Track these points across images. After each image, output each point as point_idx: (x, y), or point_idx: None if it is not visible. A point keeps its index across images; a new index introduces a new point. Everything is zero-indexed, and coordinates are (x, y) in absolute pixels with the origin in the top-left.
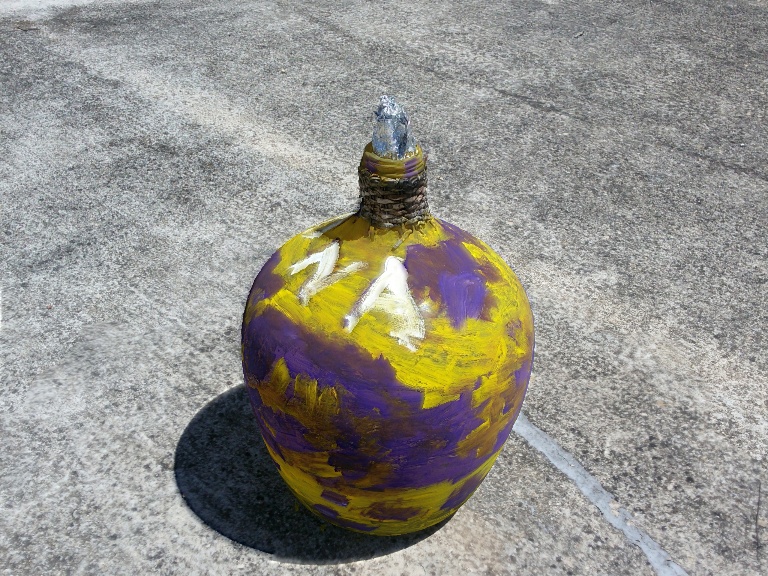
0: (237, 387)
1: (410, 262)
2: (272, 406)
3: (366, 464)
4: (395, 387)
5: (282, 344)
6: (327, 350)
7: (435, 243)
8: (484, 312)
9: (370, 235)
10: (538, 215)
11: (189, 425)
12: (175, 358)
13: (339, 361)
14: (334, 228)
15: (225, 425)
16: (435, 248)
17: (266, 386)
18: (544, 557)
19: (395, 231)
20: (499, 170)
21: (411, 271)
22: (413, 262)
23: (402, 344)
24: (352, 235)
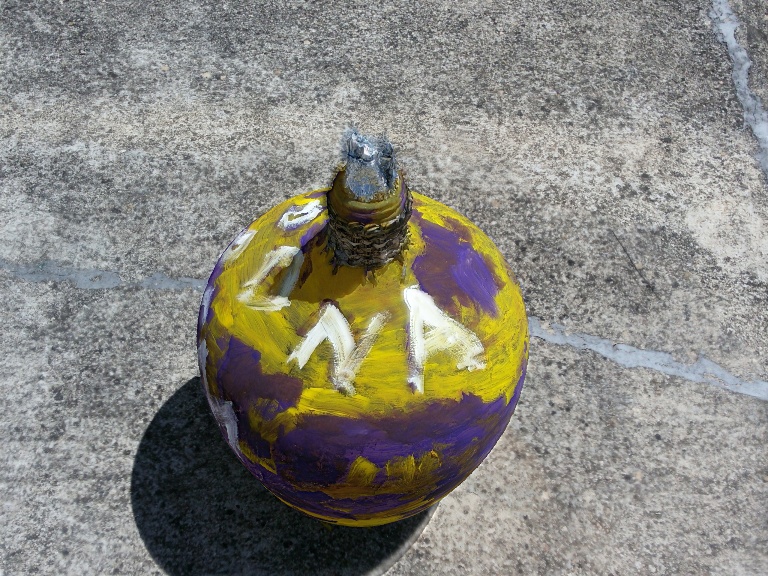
0: (140, 451)
1: (425, 283)
2: (350, 497)
3: (460, 478)
4: (485, 411)
5: (353, 446)
6: (411, 424)
7: (423, 244)
8: (496, 281)
9: (369, 280)
10: (223, 49)
11: (139, 529)
12: (35, 468)
13: (429, 426)
14: (299, 285)
15: (174, 500)
16: (427, 249)
17: (341, 487)
18: (541, 410)
19: (394, 261)
20: (132, 8)
21: (432, 292)
22: (427, 281)
23: (473, 370)
24: (345, 289)
